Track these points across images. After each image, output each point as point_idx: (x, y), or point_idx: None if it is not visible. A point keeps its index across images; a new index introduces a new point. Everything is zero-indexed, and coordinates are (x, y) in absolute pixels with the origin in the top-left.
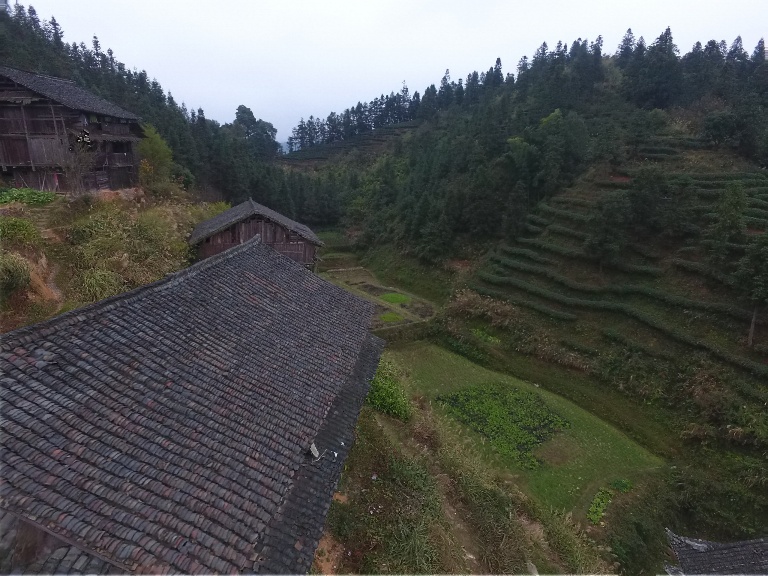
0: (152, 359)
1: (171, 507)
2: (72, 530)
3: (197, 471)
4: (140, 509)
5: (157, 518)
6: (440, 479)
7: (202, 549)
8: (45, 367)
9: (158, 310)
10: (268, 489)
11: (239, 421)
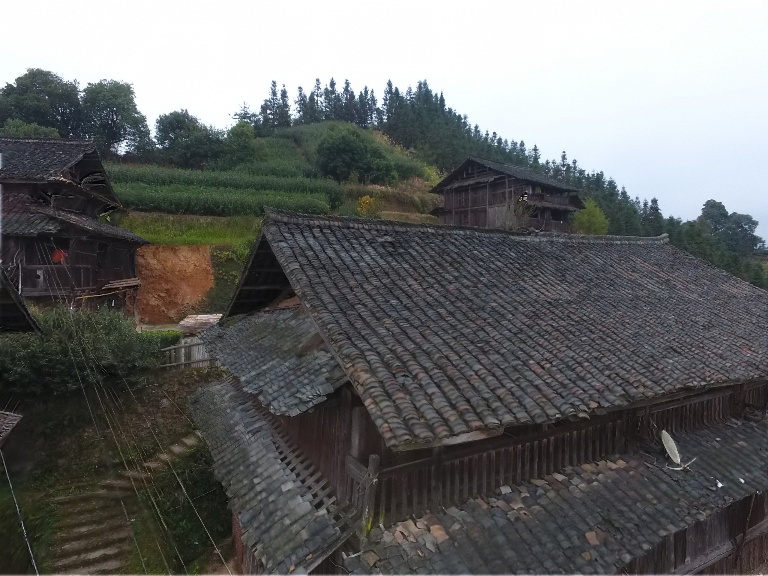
0: (475, 268)
1: (414, 348)
2: (324, 321)
3: (462, 342)
4: (385, 335)
5: (394, 347)
6: None
7: (419, 389)
8: (383, 242)
9: (504, 247)
10: (544, 397)
11: (543, 335)
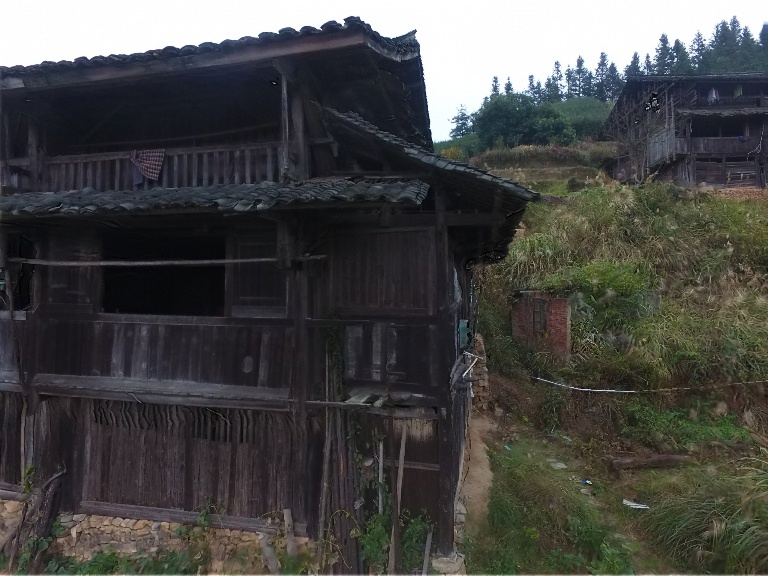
0: None
1: None
2: None
3: None
4: None
5: None
6: None
7: None
8: None
9: None
10: None
11: None
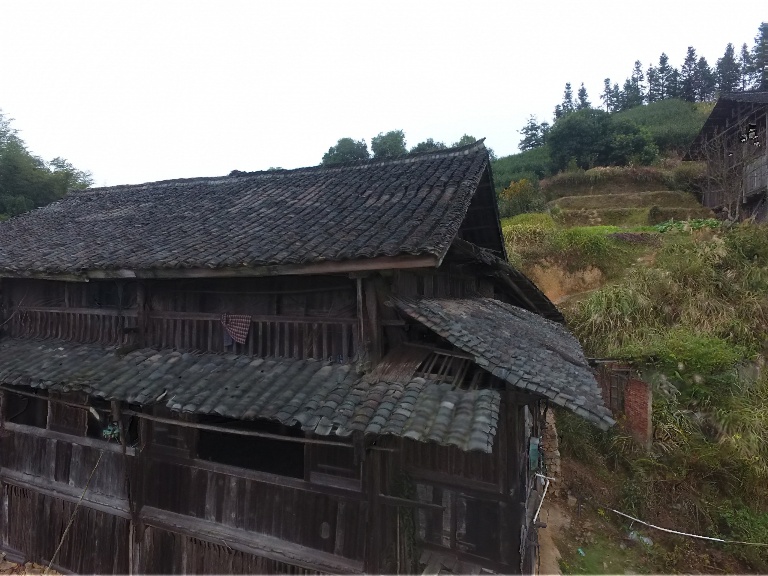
0: None
1: None
2: None
3: None
4: None
5: None
6: None
7: None
8: None
9: None
10: None
11: None
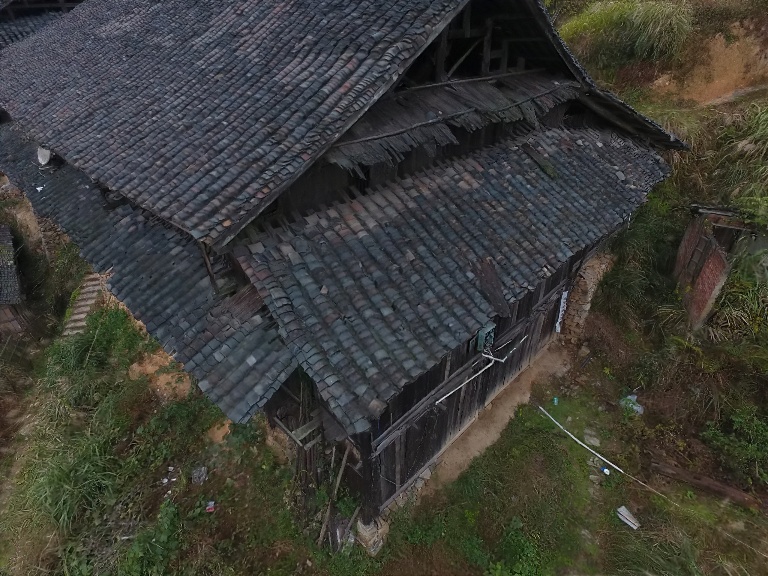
0: None
1: None
2: None
3: None
4: None
5: None
6: None
7: None
8: None
9: None
10: None
11: None
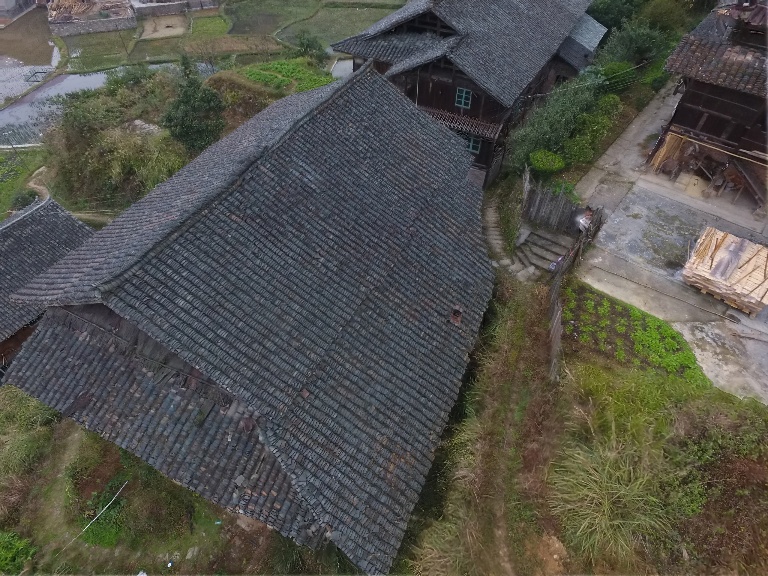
0: None
1: None
2: None
3: None
4: None
5: None
6: (67, 423)
7: None
8: None
9: None
10: None
11: None
